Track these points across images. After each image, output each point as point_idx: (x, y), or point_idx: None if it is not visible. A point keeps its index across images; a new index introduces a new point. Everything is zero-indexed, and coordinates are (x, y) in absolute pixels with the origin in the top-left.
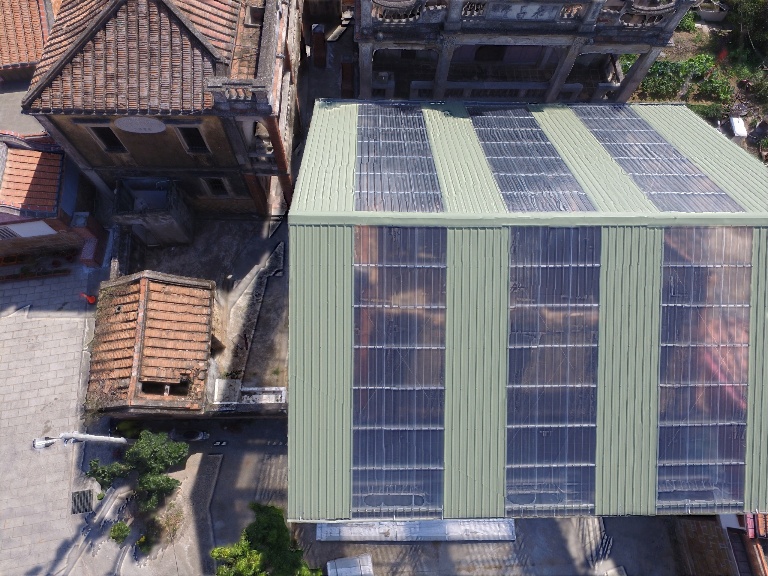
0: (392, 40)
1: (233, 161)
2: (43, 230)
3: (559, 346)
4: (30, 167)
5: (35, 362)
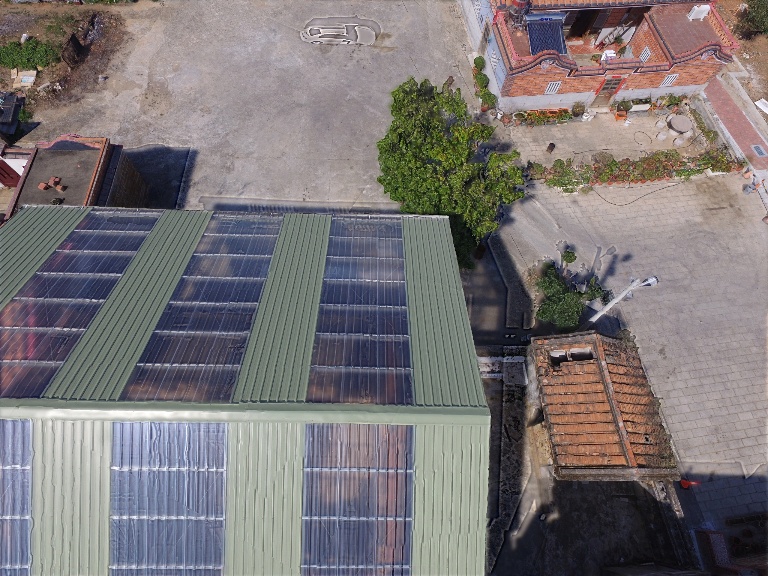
0: None
1: None
2: None
3: (208, 303)
4: None
5: (706, 414)
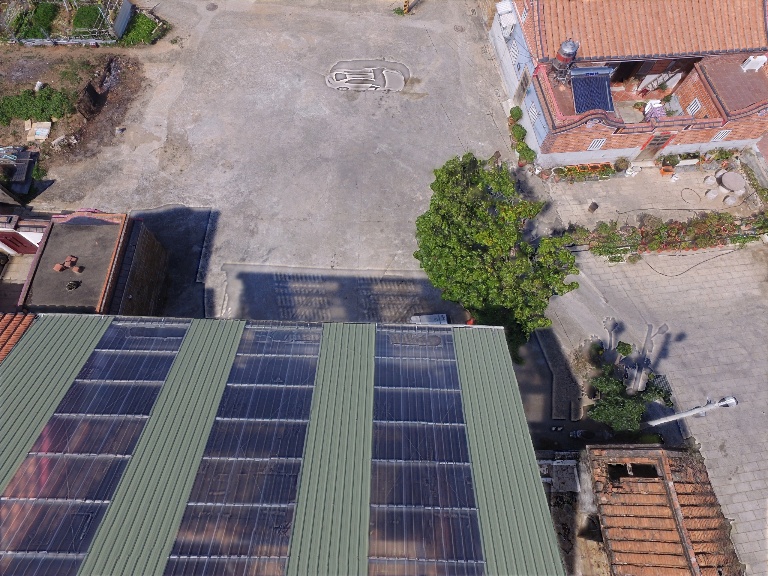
0: None
1: None
2: None
3: (246, 459)
4: None
5: None
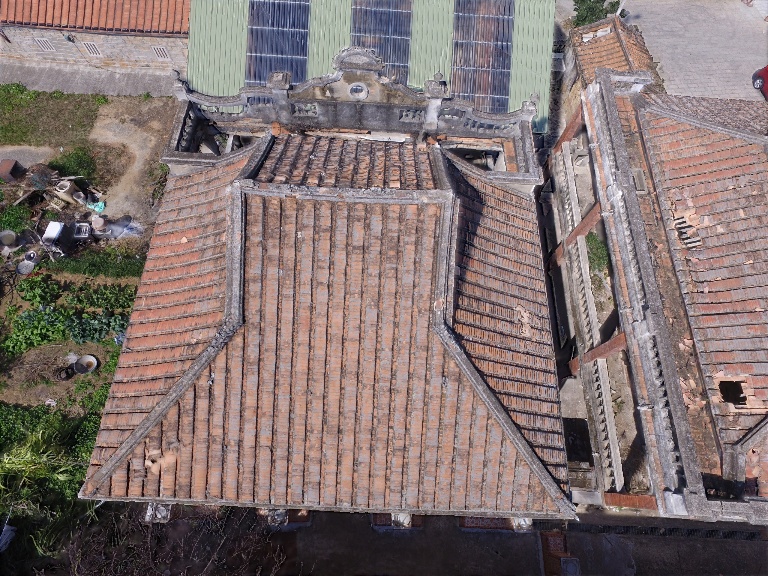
0: None
1: None
2: None
3: None
4: None
5: None
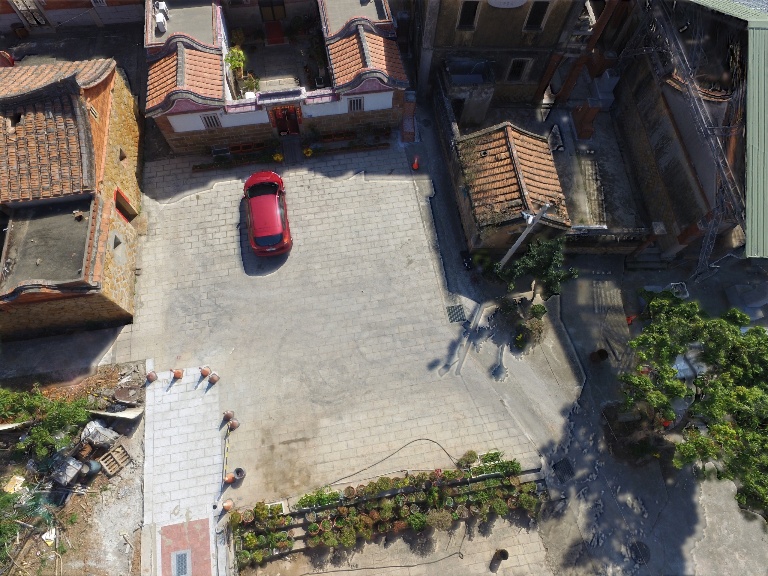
0: None
1: (553, 40)
2: (383, 104)
3: None
4: (380, 48)
5: (383, 213)
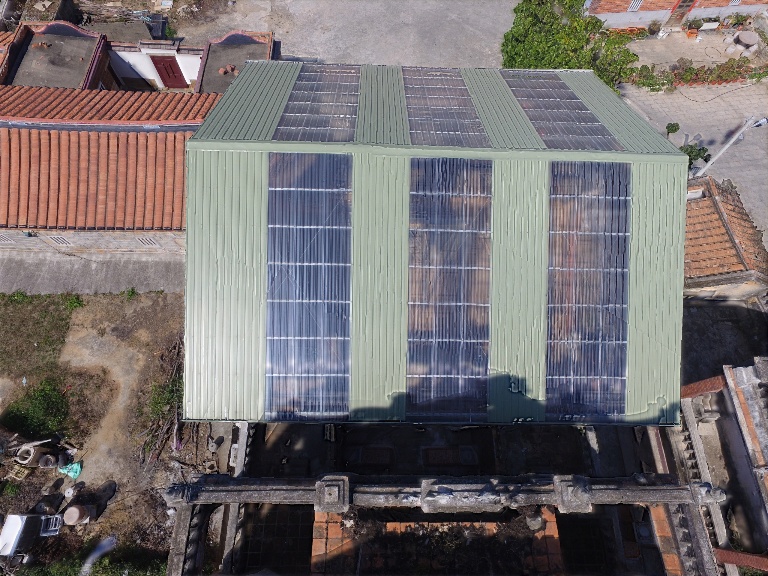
0: (621, 478)
1: None
2: None
3: (437, 107)
4: None
5: None
